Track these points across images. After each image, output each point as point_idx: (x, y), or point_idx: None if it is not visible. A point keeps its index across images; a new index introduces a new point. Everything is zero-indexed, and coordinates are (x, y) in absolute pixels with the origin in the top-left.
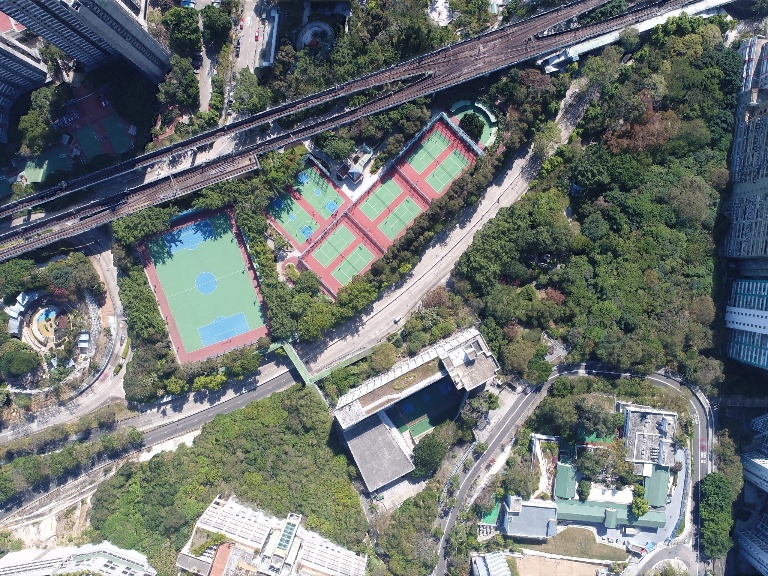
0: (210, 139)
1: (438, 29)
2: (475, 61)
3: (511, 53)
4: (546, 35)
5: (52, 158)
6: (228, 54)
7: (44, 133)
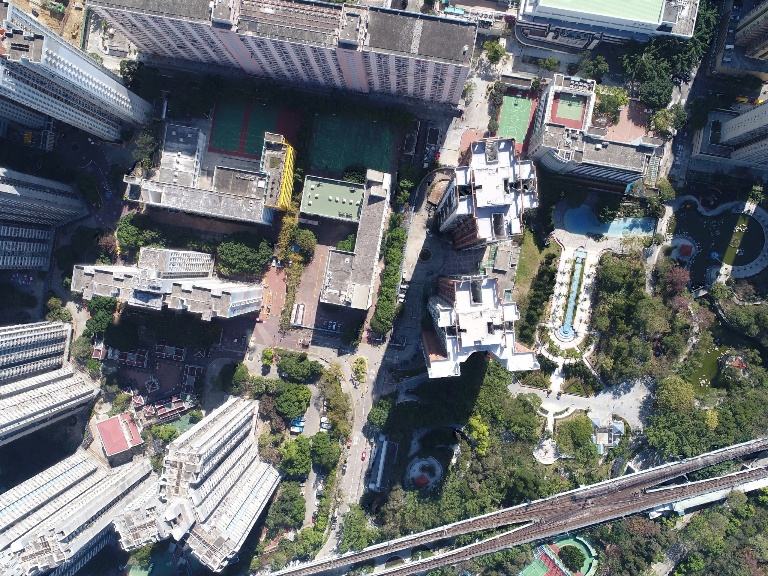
0: (316, 568)
1: (545, 473)
2: (581, 510)
3: (617, 505)
4: (653, 491)
5: (157, 561)
6: (335, 475)
7: (153, 549)
